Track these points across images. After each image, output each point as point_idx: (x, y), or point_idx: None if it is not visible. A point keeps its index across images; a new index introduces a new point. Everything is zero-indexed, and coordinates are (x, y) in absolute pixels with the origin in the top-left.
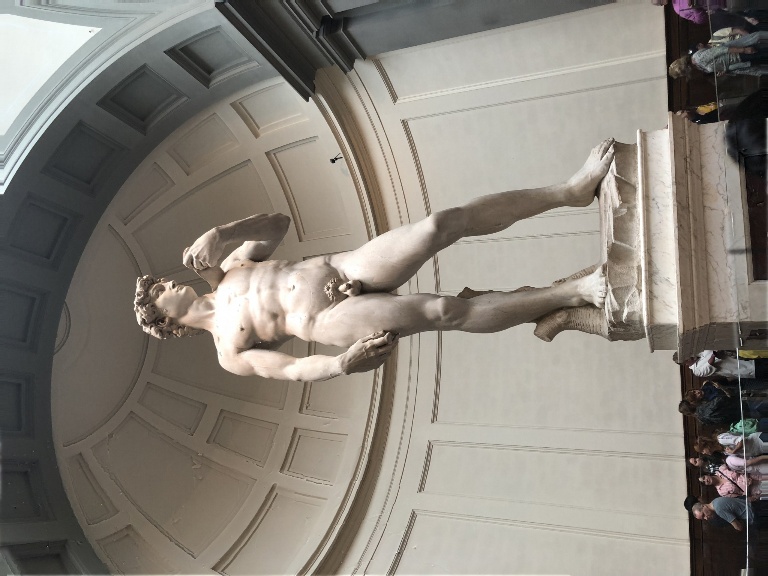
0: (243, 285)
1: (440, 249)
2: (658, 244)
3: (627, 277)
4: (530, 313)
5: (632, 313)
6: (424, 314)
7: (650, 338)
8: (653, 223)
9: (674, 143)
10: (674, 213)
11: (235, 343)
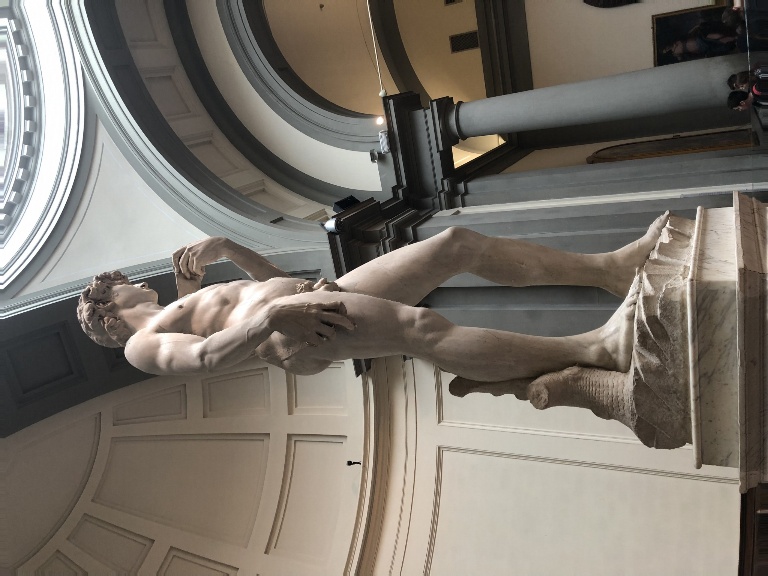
0: (213, 285)
1: (446, 266)
2: (714, 246)
3: (669, 270)
4: (530, 352)
5: (671, 290)
6: (397, 312)
7: (695, 366)
8: (709, 239)
9: (739, 200)
10: (736, 220)
11: (162, 320)
